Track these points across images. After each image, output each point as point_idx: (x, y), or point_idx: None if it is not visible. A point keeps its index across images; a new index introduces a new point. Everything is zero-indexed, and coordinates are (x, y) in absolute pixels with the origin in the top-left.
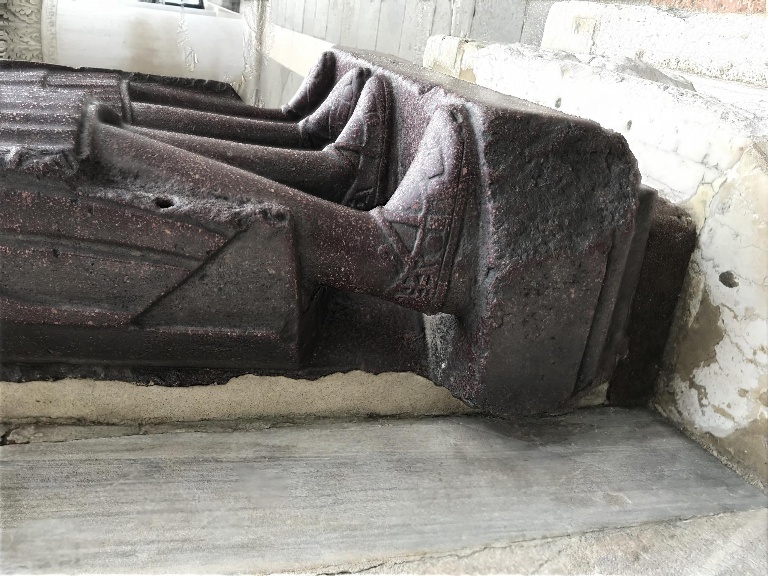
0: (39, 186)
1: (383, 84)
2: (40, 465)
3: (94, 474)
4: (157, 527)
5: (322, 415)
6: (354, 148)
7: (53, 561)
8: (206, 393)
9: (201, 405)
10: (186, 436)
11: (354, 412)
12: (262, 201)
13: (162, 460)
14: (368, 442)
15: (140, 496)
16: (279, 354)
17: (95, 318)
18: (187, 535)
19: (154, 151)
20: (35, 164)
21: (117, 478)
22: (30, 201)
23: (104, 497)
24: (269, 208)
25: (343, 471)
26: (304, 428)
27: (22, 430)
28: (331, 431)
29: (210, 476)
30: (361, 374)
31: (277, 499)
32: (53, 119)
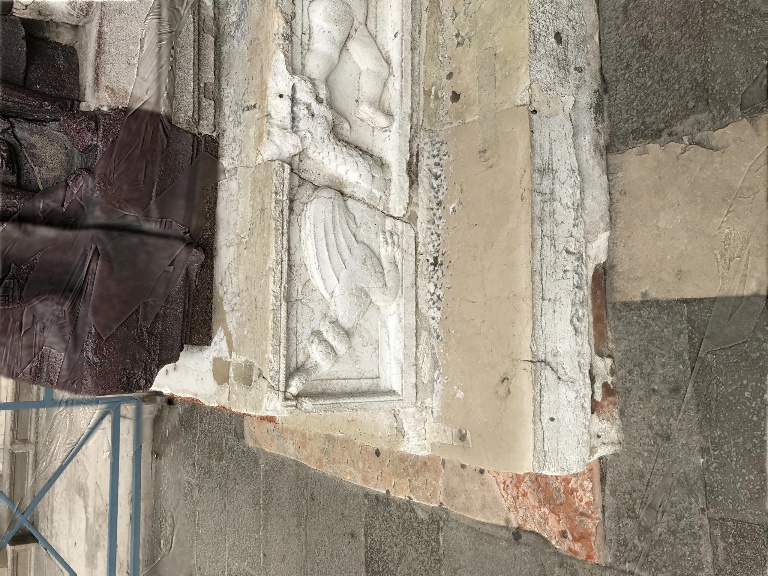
0: None
1: None
2: None
3: None
4: None
5: None
6: None
7: None
8: None
9: None
10: None
11: None
12: None
13: None
14: None
15: None
16: None
17: None
18: None
19: None
20: None
21: None
22: None
23: None
24: None
25: None
26: None
27: None
28: None
29: None
30: None
31: None
32: None
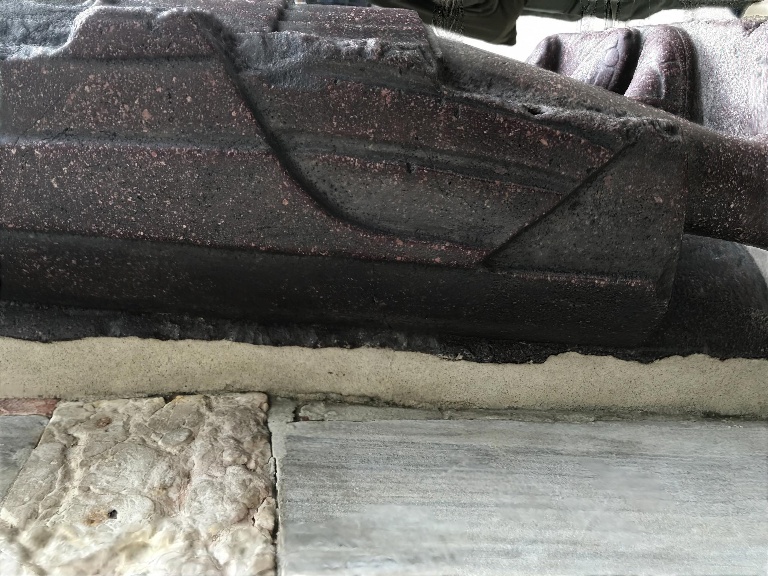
0: (399, 83)
1: (677, 32)
2: (351, 444)
3: (419, 458)
4: (529, 525)
5: (650, 411)
6: (652, 101)
7: (423, 556)
8: (518, 374)
9: (510, 389)
10: (502, 424)
11: (688, 409)
12: (639, 115)
13: (490, 448)
14: (727, 444)
15: (488, 486)
16: (643, 316)
17: (444, 253)
18: (573, 537)
19: (503, 59)
20: (399, 54)
21: (448, 464)
22: (389, 100)
23: (446, 484)
24: (656, 120)
25: (723, 474)
26: (637, 423)
27: (312, 407)
28: (672, 429)
29: (559, 469)
30: (704, 359)
31: (661, 502)
32: (395, 19)
